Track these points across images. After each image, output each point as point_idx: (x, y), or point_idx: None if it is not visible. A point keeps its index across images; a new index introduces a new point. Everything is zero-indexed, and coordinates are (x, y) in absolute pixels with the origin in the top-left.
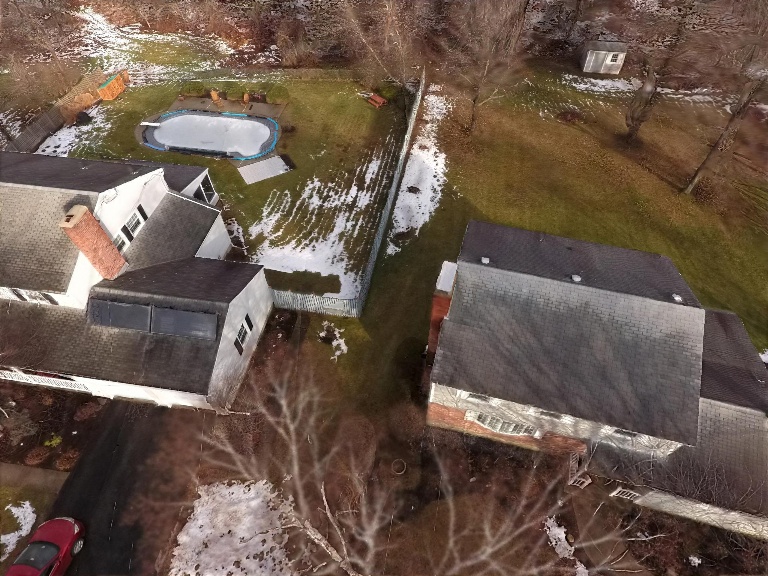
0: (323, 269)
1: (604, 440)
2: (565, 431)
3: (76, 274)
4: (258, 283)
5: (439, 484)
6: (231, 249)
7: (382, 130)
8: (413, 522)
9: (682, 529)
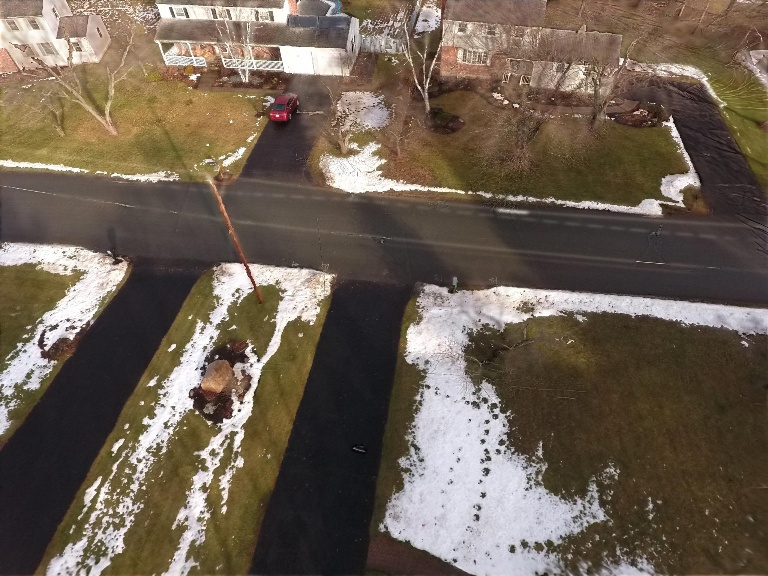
0: None
1: (513, 46)
2: (498, 46)
3: (285, 3)
4: (357, 25)
5: (447, 88)
6: None
7: (403, 2)
8: (436, 98)
9: (549, 92)
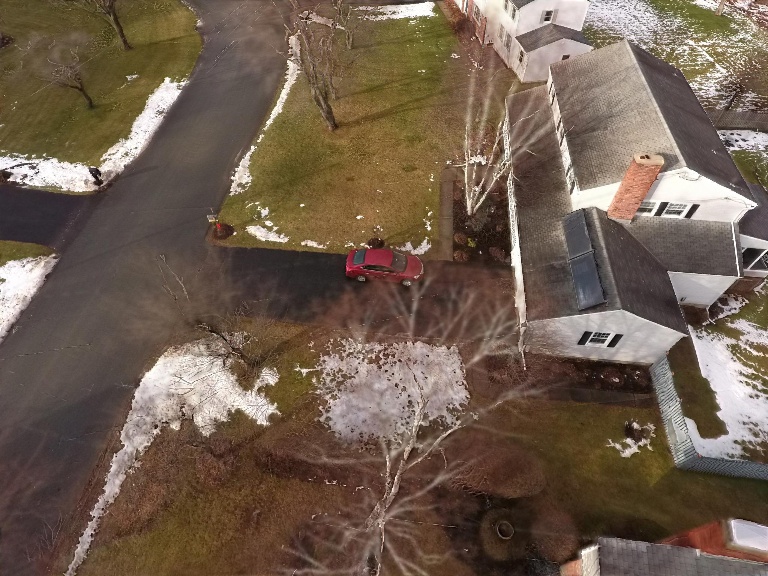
0: (728, 413)
1: None
2: None
3: (599, 190)
4: (664, 336)
5: None
6: (702, 308)
7: None
8: (453, 551)
9: None
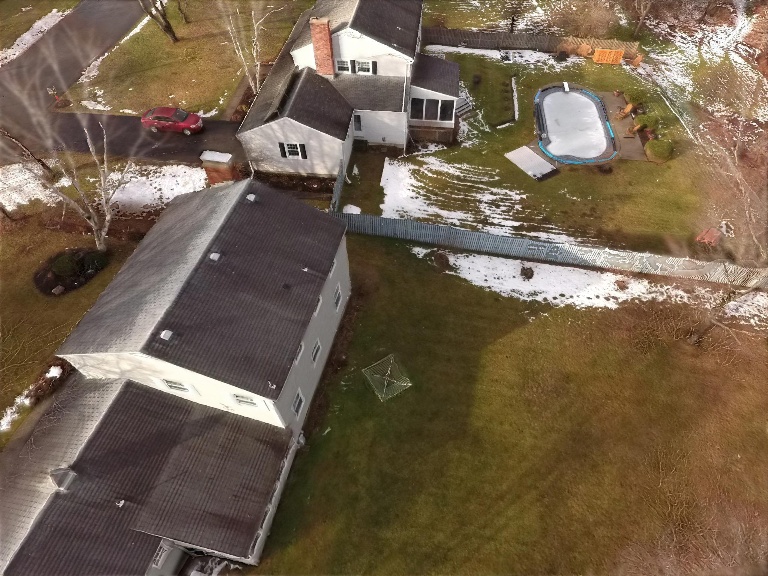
0: (388, 205)
1: None
2: None
3: (303, 50)
4: (330, 143)
5: None
6: (402, 148)
7: (644, 245)
8: None
9: None
